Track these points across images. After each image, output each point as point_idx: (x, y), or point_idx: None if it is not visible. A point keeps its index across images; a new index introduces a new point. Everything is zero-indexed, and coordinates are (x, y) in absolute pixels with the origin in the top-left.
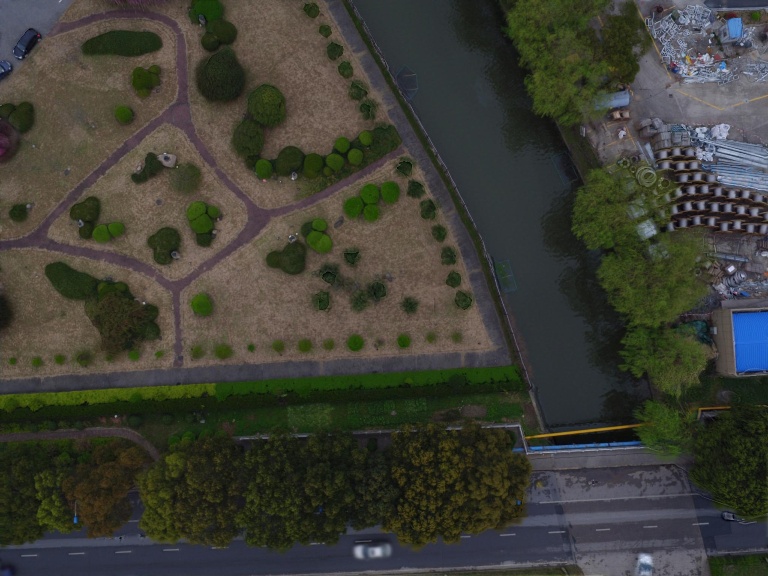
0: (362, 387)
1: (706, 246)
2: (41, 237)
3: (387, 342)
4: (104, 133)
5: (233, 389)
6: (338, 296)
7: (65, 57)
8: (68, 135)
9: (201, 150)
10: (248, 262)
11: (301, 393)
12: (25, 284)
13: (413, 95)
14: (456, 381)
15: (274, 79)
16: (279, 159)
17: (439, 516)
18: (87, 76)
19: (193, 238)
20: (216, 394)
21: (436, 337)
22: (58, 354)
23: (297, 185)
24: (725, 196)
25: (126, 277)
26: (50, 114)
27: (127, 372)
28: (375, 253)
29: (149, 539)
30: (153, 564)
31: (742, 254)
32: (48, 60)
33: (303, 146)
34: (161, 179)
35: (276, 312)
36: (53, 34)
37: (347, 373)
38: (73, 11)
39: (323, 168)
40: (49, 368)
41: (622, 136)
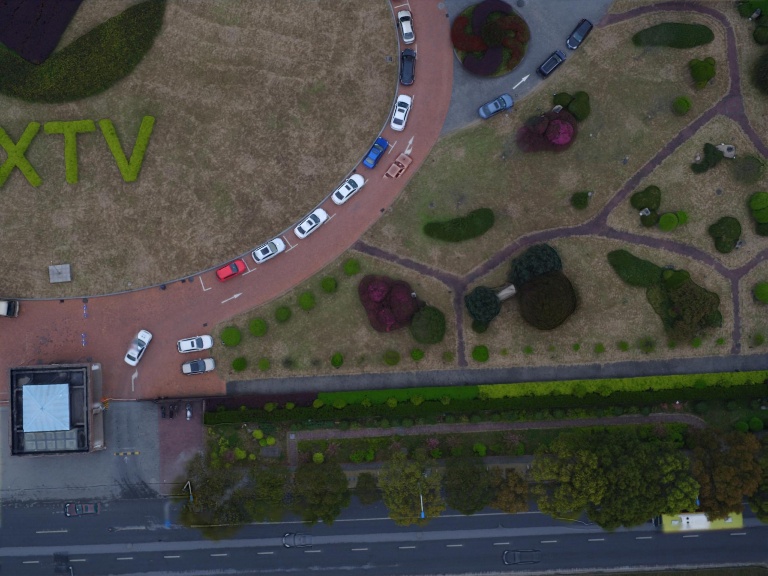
0: None
1: None
2: (600, 225)
3: None
4: (659, 123)
5: None
6: None
7: (616, 48)
8: (624, 125)
9: (755, 141)
10: None
11: None
12: (586, 271)
13: None
14: None
15: None
16: None
17: None
18: (639, 67)
19: (751, 227)
20: None
21: None
22: (620, 340)
23: None
24: None
25: (686, 265)
26: (604, 104)
27: (686, 359)
28: None
29: (717, 523)
30: (721, 548)
31: None
32: (599, 50)
33: None
34: (719, 169)
35: None
36: (602, 25)
37: None
38: (621, 3)
39: None
40: (610, 354)
41: None
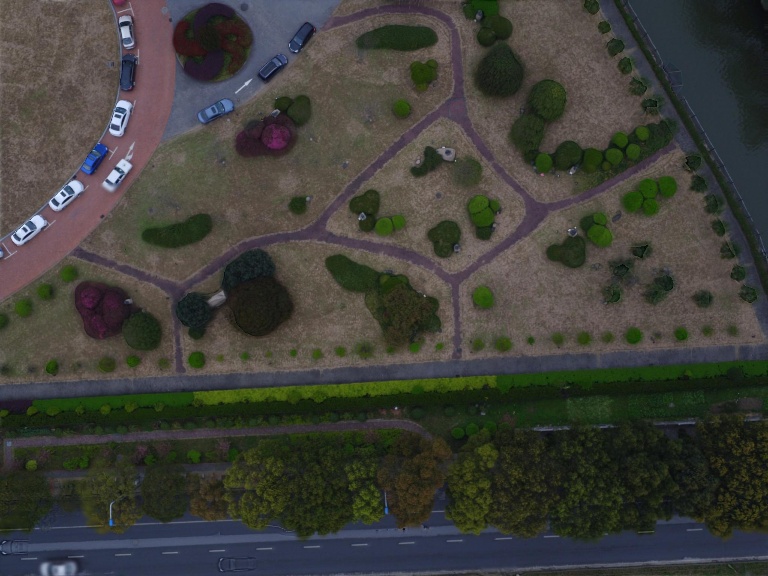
0: (641, 379)
1: None
2: (320, 230)
3: (663, 335)
4: (381, 127)
5: (514, 381)
6: None
7: (339, 51)
8: (345, 128)
9: (478, 144)
10: (527, 255)
11: (584, 385)
12: (304, 276)
13: (678, 91)
14: (736, 373)
15: (549, 74)
16: (560, 153)
17: (764, 505)
18: (362, 70)
19: (472, 231)
20: (498, 386)
21: (711, 330)
22: (338, 346)
23: (574, 179)
24: None
25: (406, 270)
26: (326, 107)
27: (406, 364)
28: (652, 247)
29: (433, 530)
30: (437, 555)
31: None
32: (322, 54)
33: (580, 141)
34: (440, 173)
35: (555, 305)
36: (327, 28)
37: (624, 366)
38: (346, 5)
39: (602, 163)
40: (328, 360)
41: None
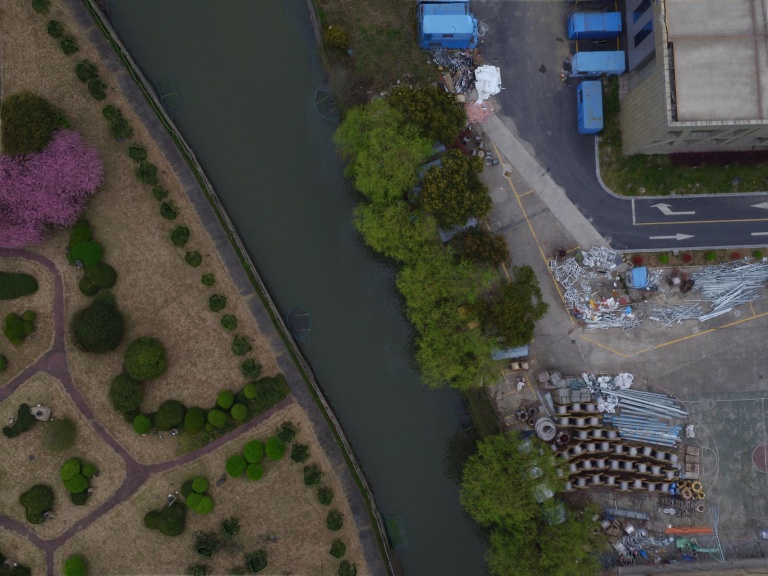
0: None
1: (607, 502)
2: None
3: None
4: None
5: None
6: (220, 558)
7: None
8: None
9: (78, 401)
10: (126, 521)
11: None
12: None
13: (305, 336)
14: None
15: (155, 326)
16: (158, 415)
17: None
18: None
19: (68, 495)
20: None
21: None
22: None
23: (178, 440)
24: (626, 453)
25: None
26: None
27: None
28: (259, 512)
29: None
30: None
31: (644, 510)
32: None
33: (185, 398)
34: (35, 432)
35: (155, 574)
36: None
37: None
38: None
39: (205, 424)
40: None
41: (520, 388)
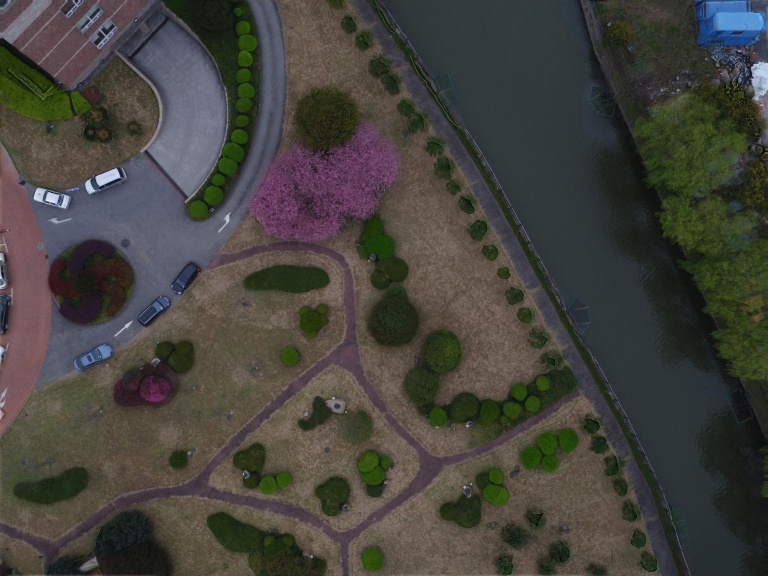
0: None
1: None
2: (202, 485)
3: None
4: (268, 374)
5: None
6: (513, 549)
7: (226, 292)
8: (230, 376)
9: (370, 394)
10: (420, 513)
11: None
12: (185, 535)
13: (585, 330)
14: None
15: (446, 319)
16: (455, 408)
17: None
18: (249, 313)
19: (363, 487)
20: None
21: None
22: None
23: (471, 432)
24: None
25: (292, 528)
26: (210, 353)
27: None
28: (552, 504)
29: None
30: None
31: None
32: (207, 294)
33: (477, 391)
34: (329, 425)
35: (449, 565)
36: (212, 266)
37: None
38: (233, 242)
39: (500, 416)
40: None
41: None
